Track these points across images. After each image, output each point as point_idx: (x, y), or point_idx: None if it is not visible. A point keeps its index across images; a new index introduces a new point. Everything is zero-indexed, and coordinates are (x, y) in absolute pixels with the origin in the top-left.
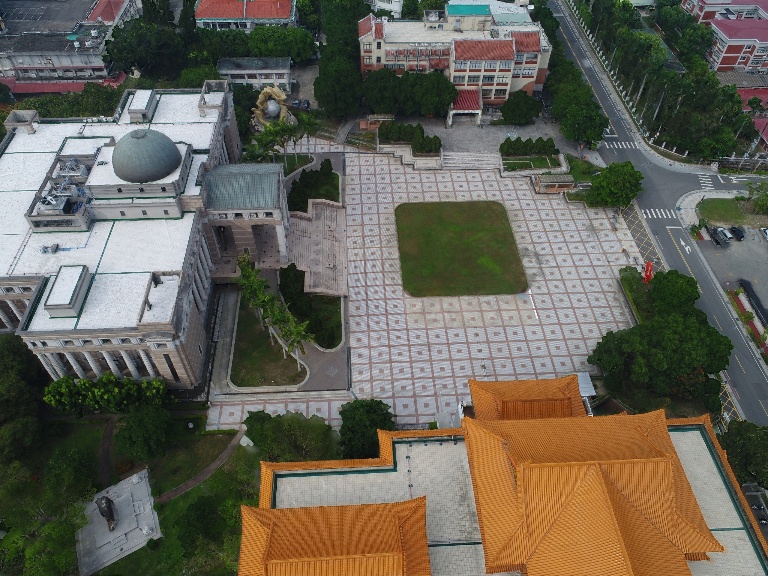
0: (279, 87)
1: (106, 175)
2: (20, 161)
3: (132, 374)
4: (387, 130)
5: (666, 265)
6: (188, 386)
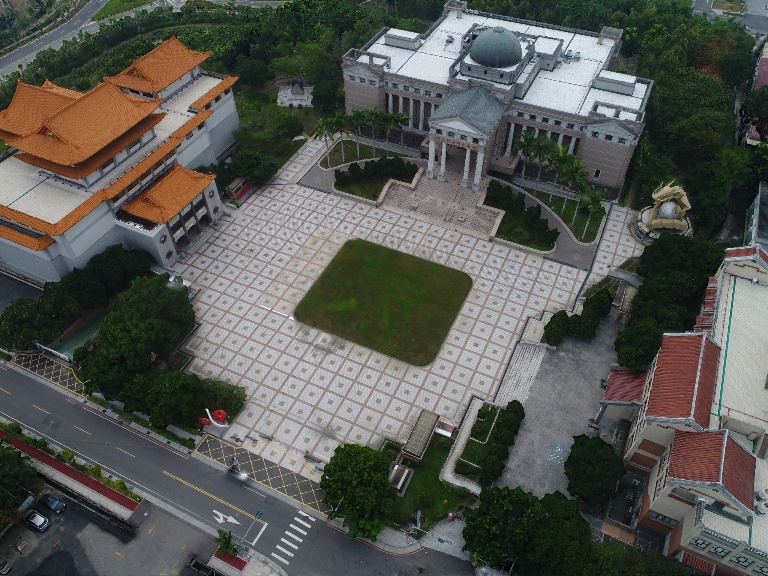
0: None
1: None
2: (561, 38)
3: None
4: None
5: (222, 467)
6: None
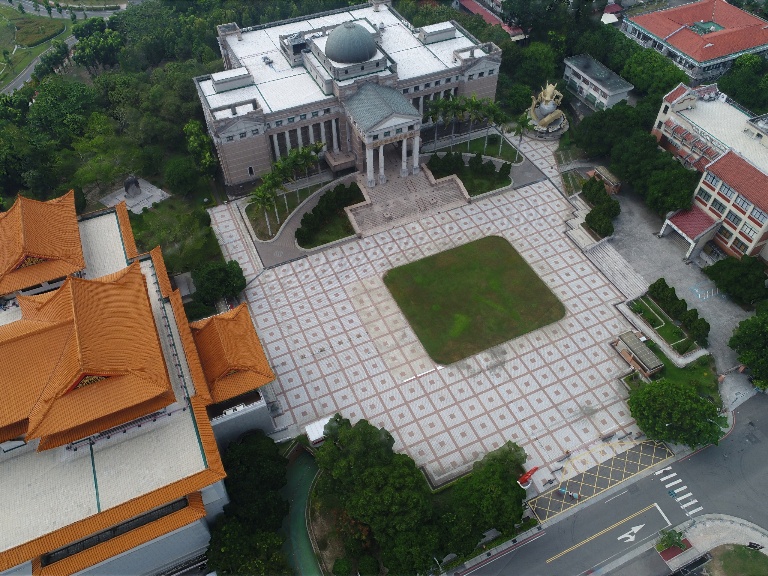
0: (599, 105)
1: None
2: (344, 19)
3: None
4: (592, 186)
5: (574, 509)
6: (226, 181)
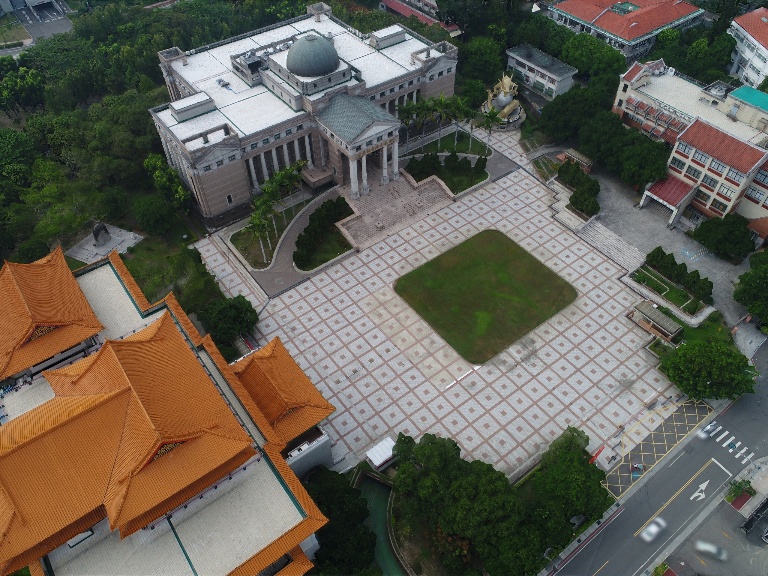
0: (547, 91)
1: (285, 57)
2: (288, 33)
3: (189, 183)
4: (568, 169)
5: (643, 480)
6: (204, 213)
